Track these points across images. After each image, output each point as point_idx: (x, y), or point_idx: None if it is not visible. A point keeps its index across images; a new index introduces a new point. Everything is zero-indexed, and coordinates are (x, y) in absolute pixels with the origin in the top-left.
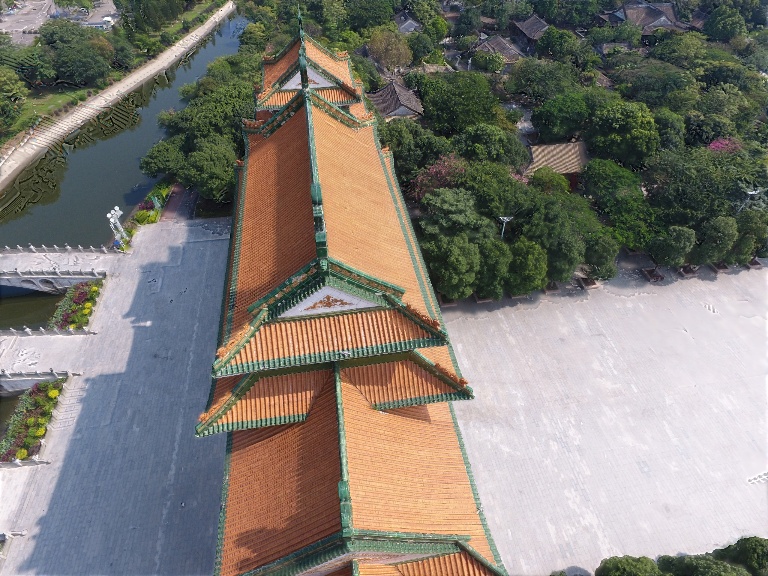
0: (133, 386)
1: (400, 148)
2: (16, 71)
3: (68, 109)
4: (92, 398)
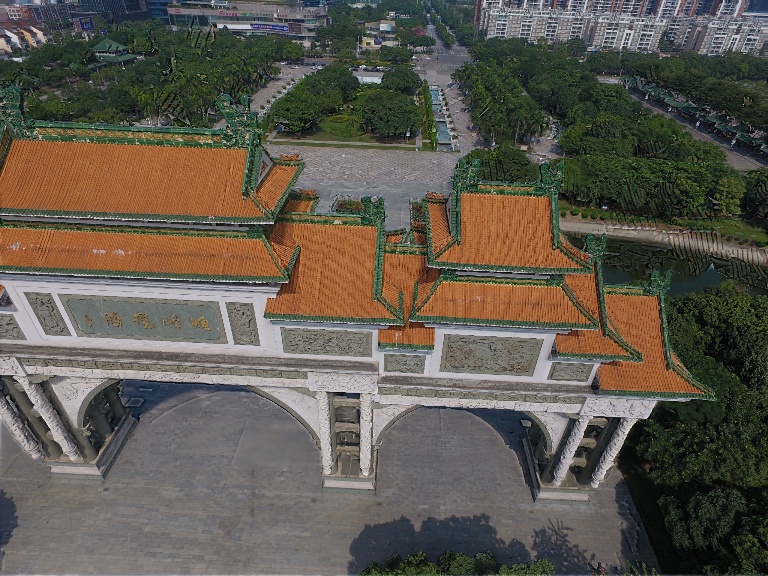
0: None
1: (750, 568)
2: (759, 195)
3: (745, 243)
4: None
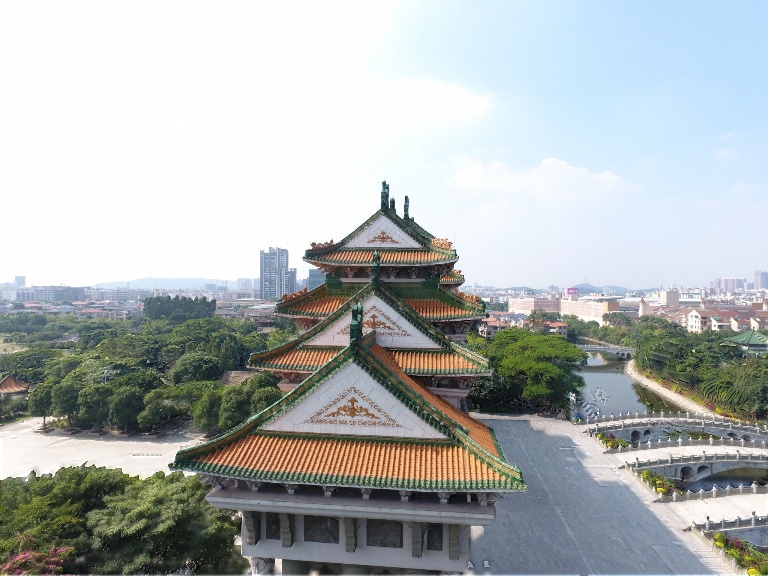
0: (657, 572)
1: None
2: None
3: None
4: (700, 569)
